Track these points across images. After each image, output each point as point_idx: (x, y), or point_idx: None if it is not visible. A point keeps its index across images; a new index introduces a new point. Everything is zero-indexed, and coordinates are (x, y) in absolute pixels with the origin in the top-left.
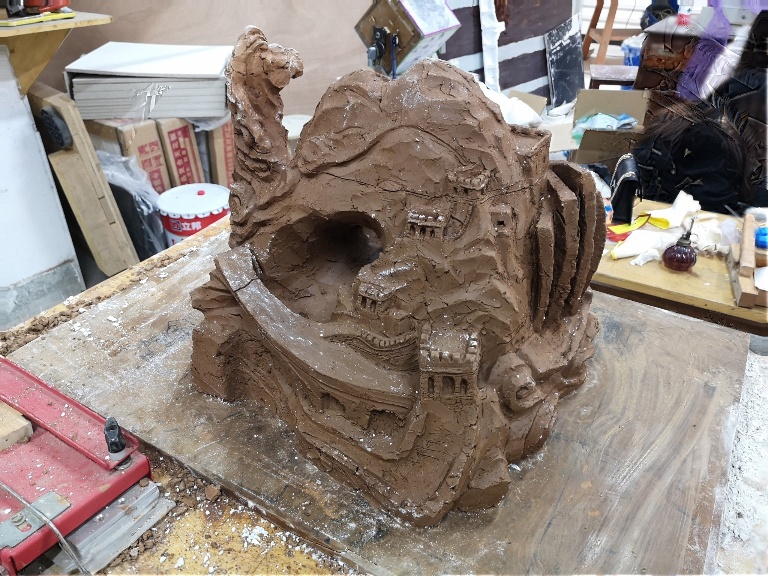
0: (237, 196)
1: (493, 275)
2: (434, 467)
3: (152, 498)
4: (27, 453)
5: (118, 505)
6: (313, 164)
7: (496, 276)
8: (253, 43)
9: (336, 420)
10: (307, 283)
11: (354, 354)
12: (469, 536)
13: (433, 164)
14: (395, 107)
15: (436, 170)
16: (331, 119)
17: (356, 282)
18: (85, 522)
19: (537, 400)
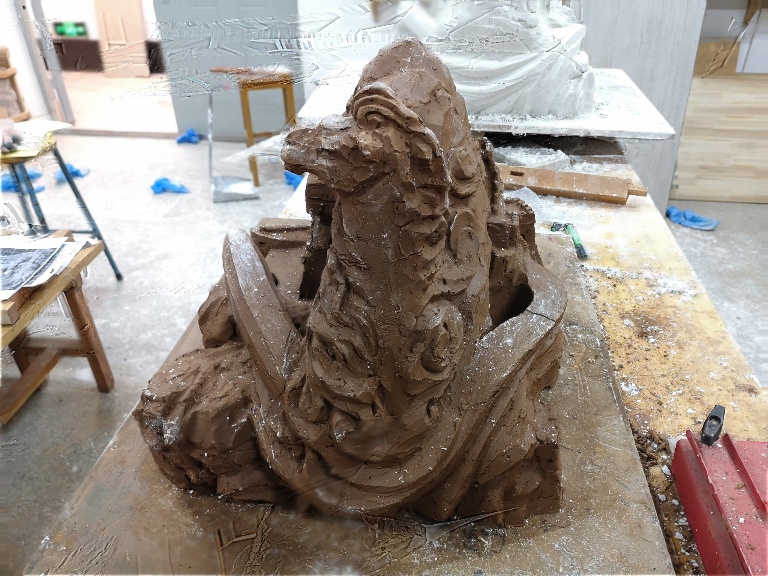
0: (443, 324)
1: None
2: None
3: None
4: None
5: None
6: None
7: None
8: None
9: None
10: None
11: None
12: None
13: None
14: None
15: None
16: None
17: None
18: None
19: None
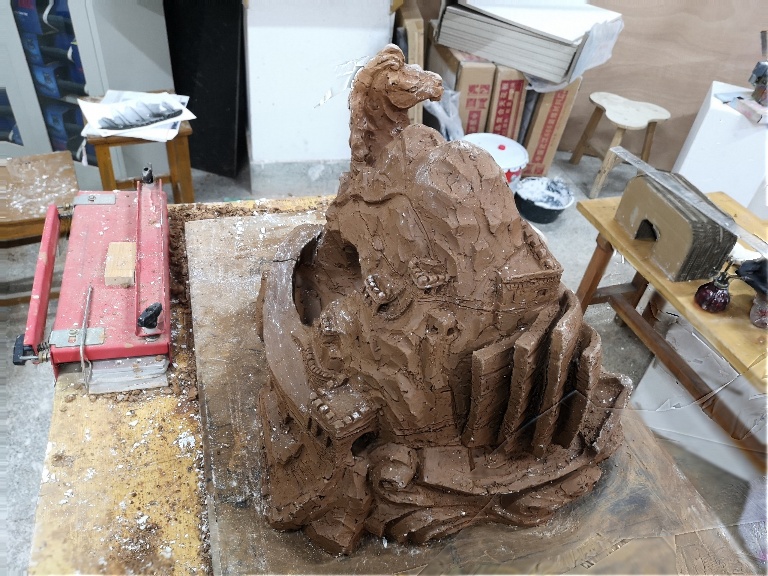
0: None
1: (402, 370)
2: (294, 488)
3: (157, 371)
4: (119, 295)
5: (134, 362)
6: (354, 191)
7: (404, 372)
8: (385, 61)
9: (272, 402)
10: (347, 283)
11: (301, 362)
12: (291, 559)
13: (406, 243)
14: (411, 175)
15: (407, 250)
16: (383, 159)
17: (329, 306)
18: (109, 359)
19: (408, 501)
